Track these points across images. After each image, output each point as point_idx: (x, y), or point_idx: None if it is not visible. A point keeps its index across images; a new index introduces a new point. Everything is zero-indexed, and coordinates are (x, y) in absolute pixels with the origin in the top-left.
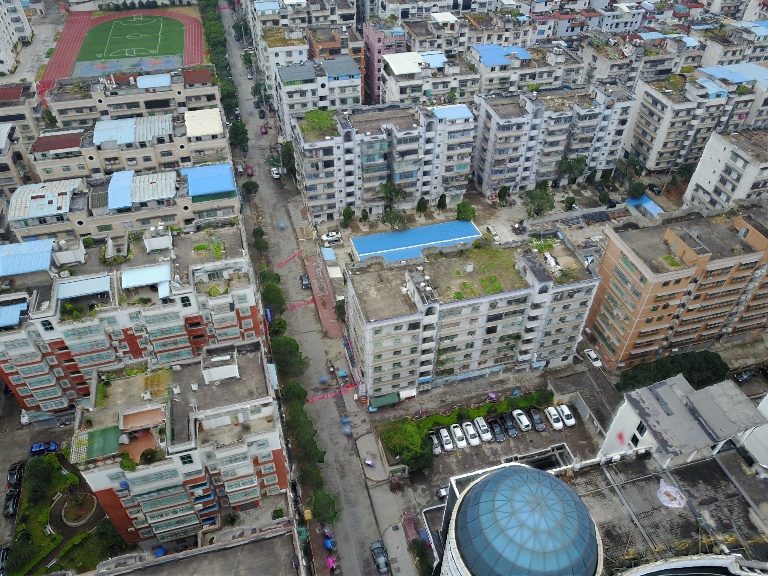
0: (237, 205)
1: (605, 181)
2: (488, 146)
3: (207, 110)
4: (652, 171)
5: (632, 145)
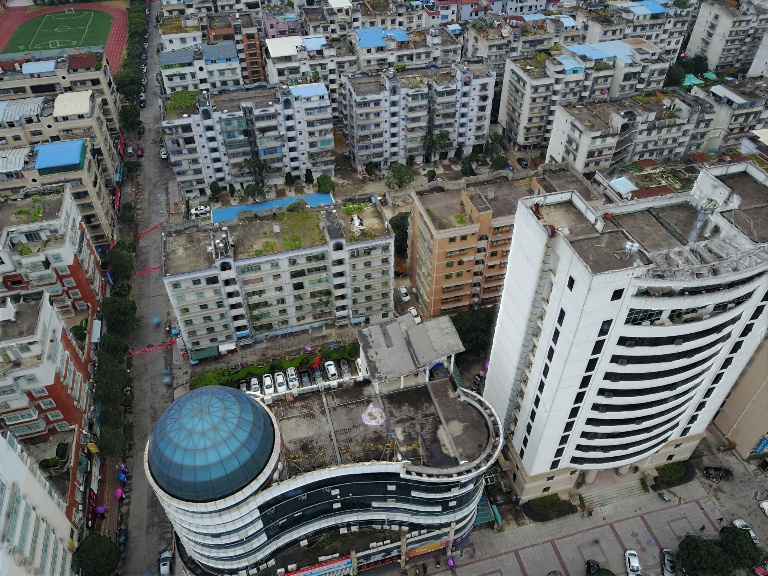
0: (85, 177)
1: (473, 156)
2: (354, 123)
3: (79, 92)
4: (522, 146)
5: (506, 122)
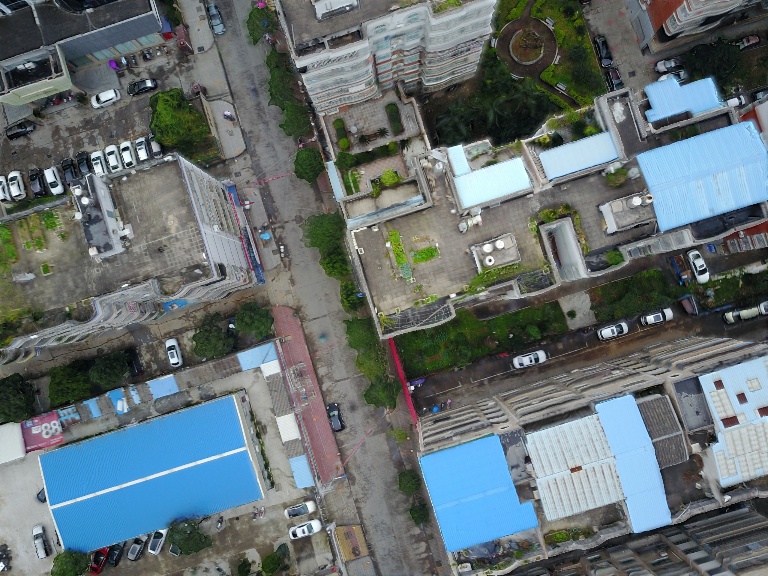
0: None
1: None
2: None
3: None
4: None
5: None
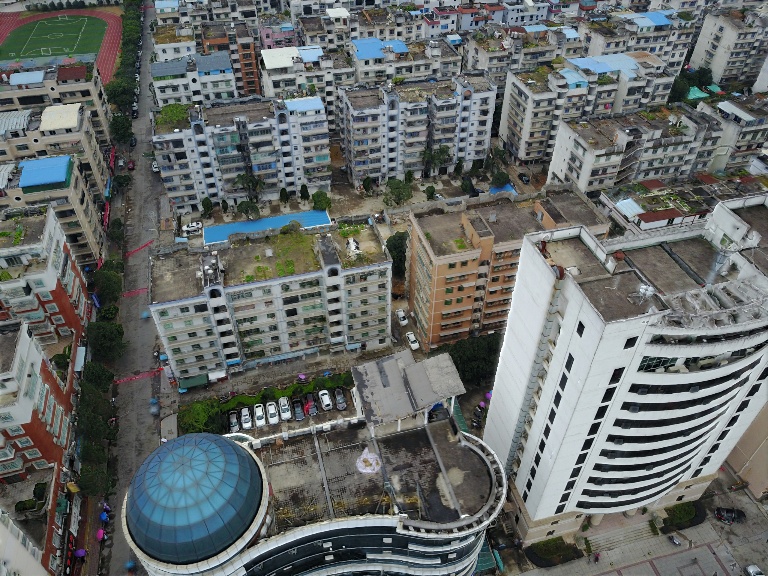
0: (71, 196)
1: (473, 171)
2: (351, 138)
3: (68, 105)
4: (523, 161)
5: (507, 136)
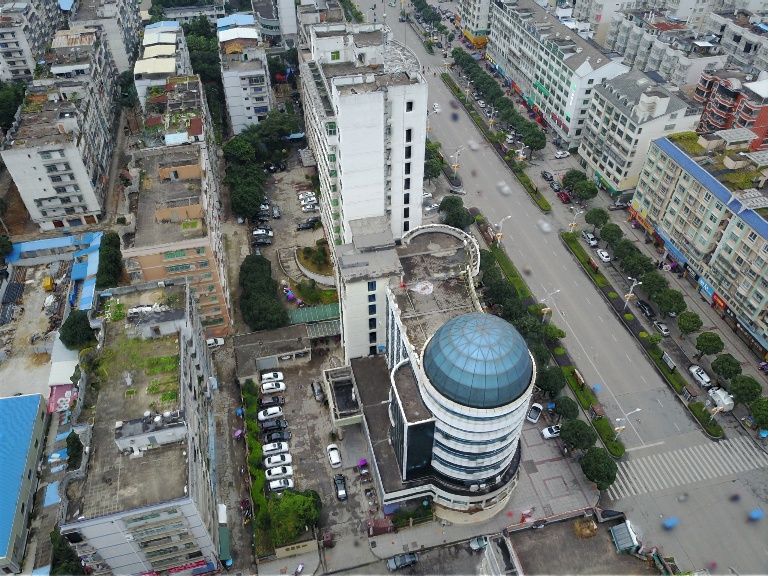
0: None
1: None
2: None
3: None
4: None
5: None
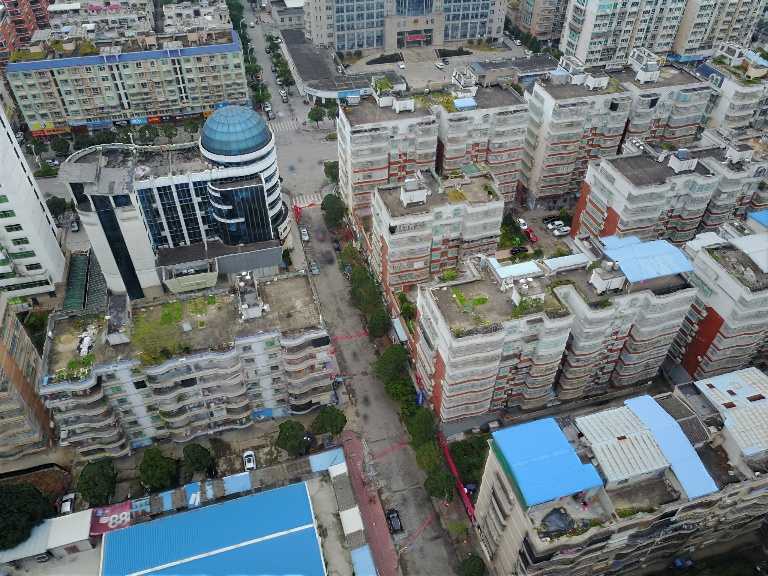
0: None
1: None
2: None
3: None
4: None
5: None
